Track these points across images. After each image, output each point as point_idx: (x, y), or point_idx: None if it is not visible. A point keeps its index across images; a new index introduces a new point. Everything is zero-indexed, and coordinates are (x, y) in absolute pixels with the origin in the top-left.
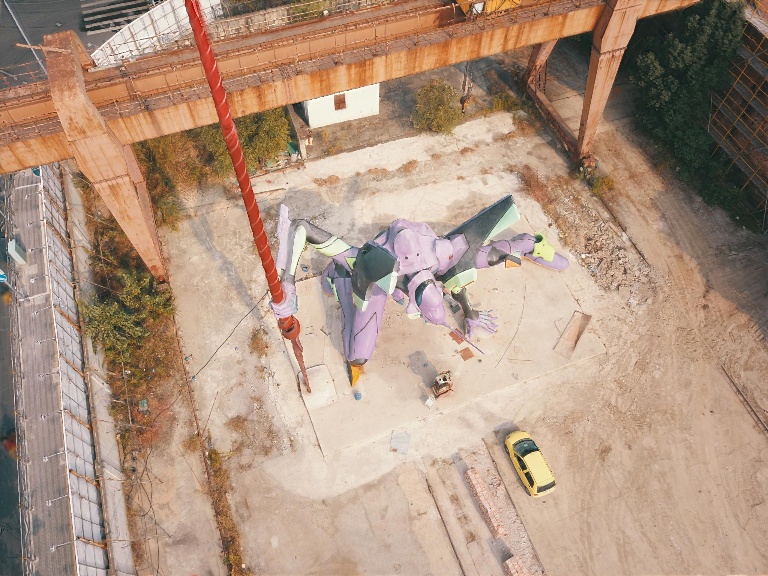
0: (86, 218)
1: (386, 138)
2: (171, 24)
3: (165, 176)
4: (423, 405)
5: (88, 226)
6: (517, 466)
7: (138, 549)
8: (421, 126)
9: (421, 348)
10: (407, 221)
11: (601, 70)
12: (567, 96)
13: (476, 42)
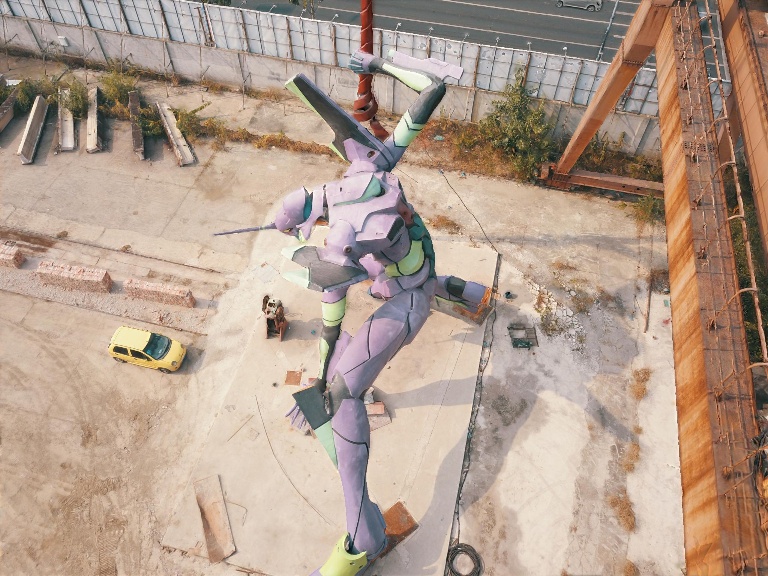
0: None
1: None
2: None
3: None
4: None
5: None
6: None
7: None
8: None
9: None
10: (392, 203)
11: None
12: None
13: None
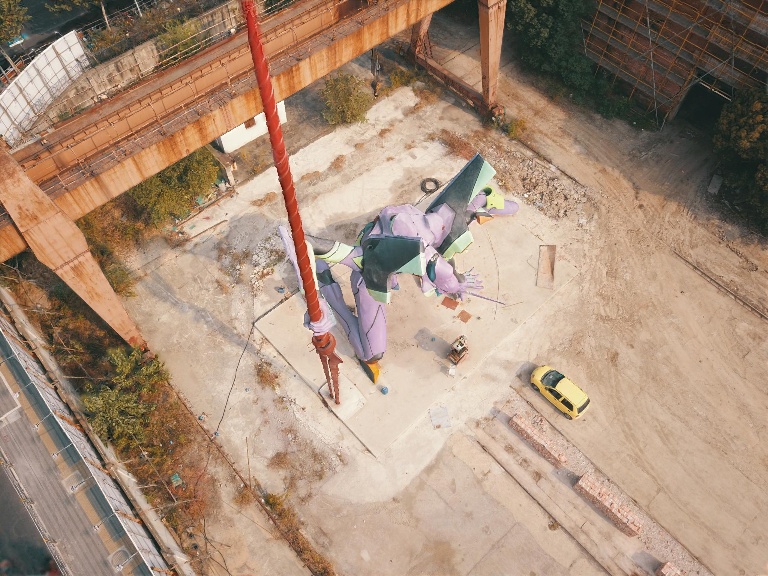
0: (26, 316)
1: (304, 142)
2: (40, 88)
3: (99, 245)
4: (446, 376)
5: (32, 323)
6: (551, 398)
7: None
8: (336, 121)
9: (422, 326)
10: None
11: (492, 23)
12: (452, 57)
13: (384, 24)
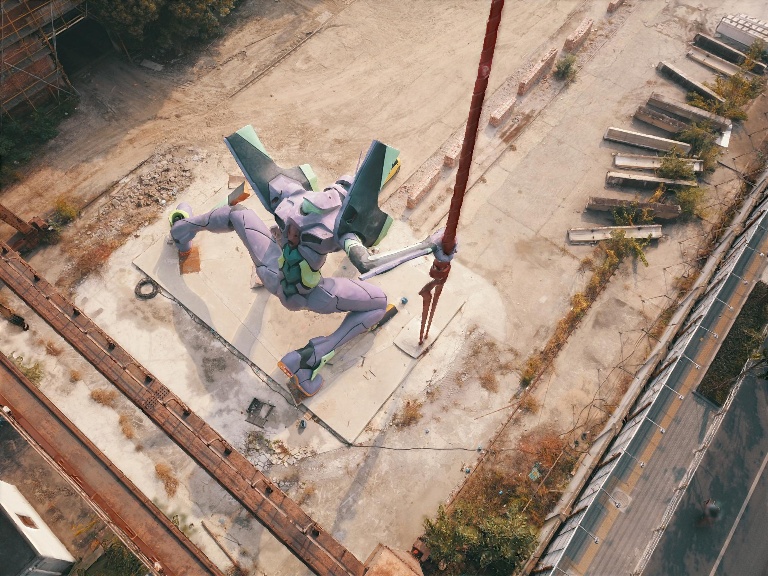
0: None
1: None
2: None
3: None
4: None
5: None
6: None
7: (624, 386)
8: None
9: None
10: (289, 214)
11: None
12: None
13: None
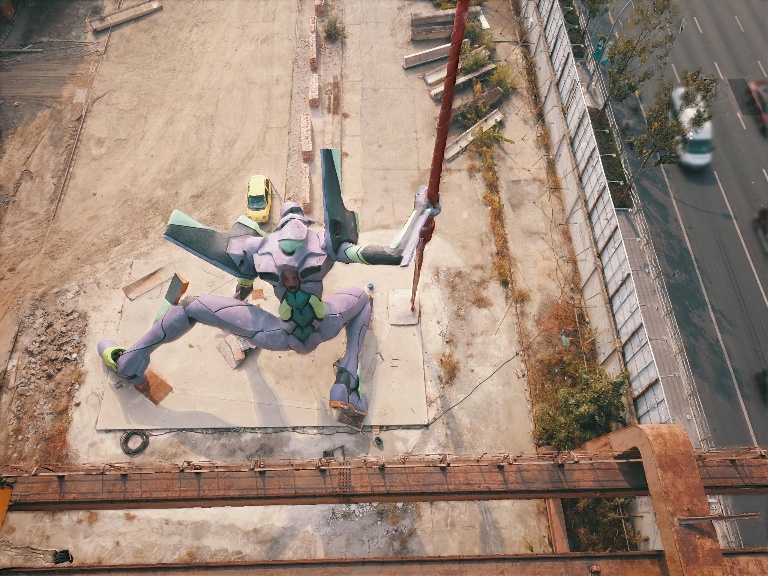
0: None
1: None
2: None
3: None
4: None
5: None
6: None
7: (566, 237)
8: None
9: None
10: (278, 263)
11: None
12: None
13: None
